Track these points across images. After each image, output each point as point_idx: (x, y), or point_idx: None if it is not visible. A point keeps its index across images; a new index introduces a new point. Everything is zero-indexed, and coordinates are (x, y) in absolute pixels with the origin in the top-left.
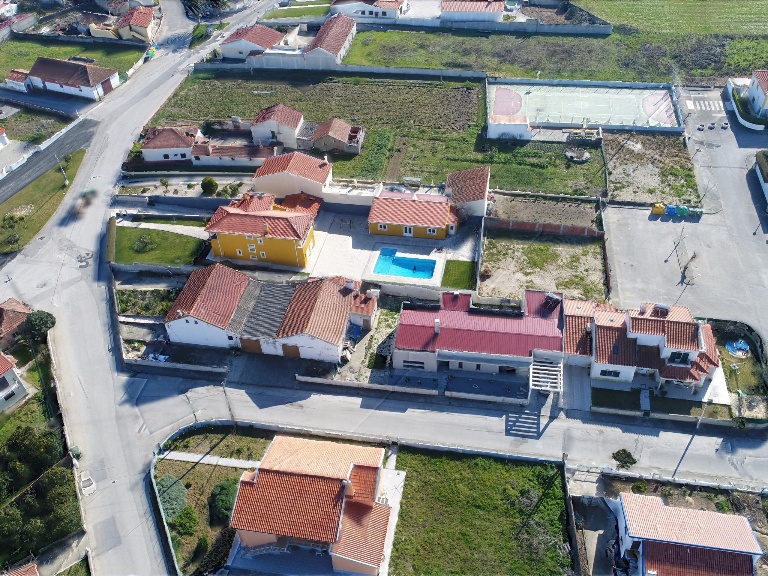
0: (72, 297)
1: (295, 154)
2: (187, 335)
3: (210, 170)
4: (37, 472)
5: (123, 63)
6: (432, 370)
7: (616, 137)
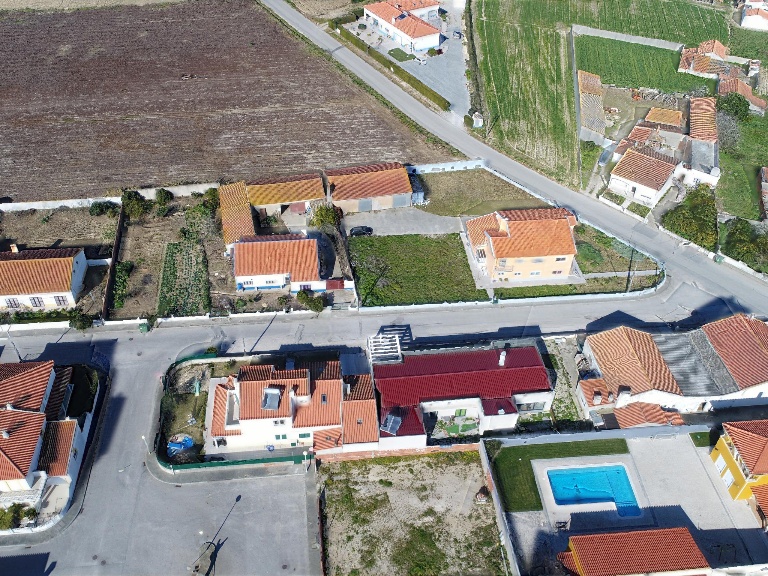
0: None
1: None
2: None
3: None
4: None
5: None
6: None
7: None
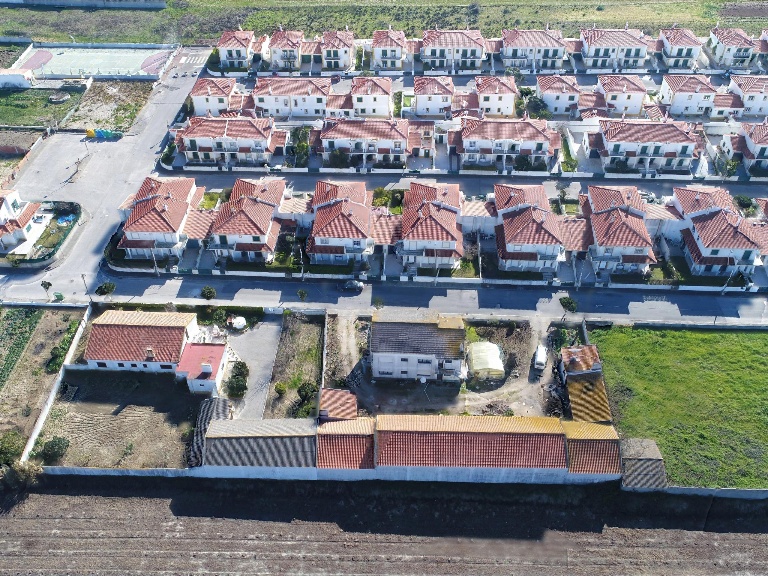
0: None
1: None
2: None
3: None
4: None
5: None
6: None
7: (103, 84)
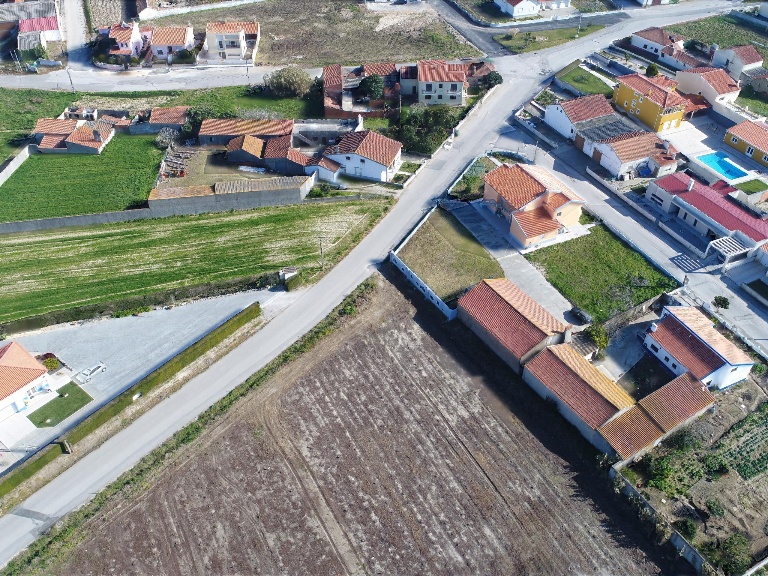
0: (521, 83)
1: (720, 69)
2: (553, 119)
3: (665, 66)
4: None
5: None
6: (666, 210)
7: None
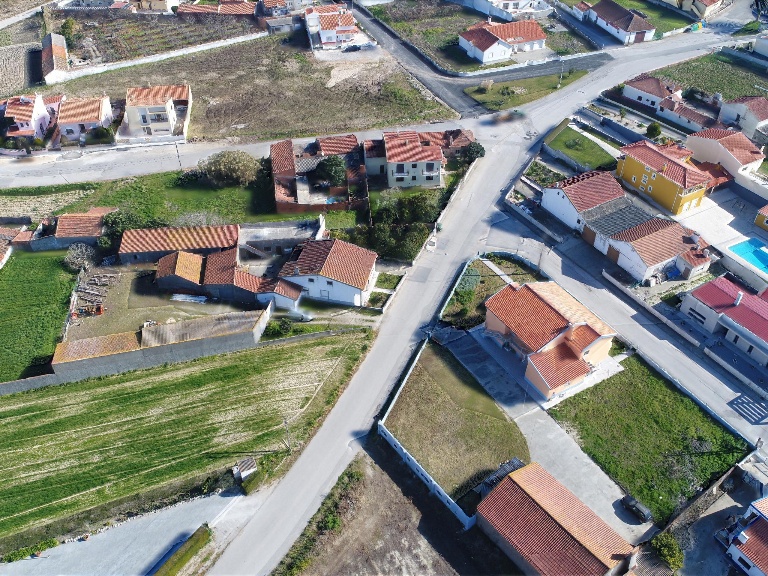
0: (505, 151)
1: (738, 133)
2: (553, 205)
3: (665, 122)
4: (413, 222)
5: (667, 27)
6: (709, 329)
7: None
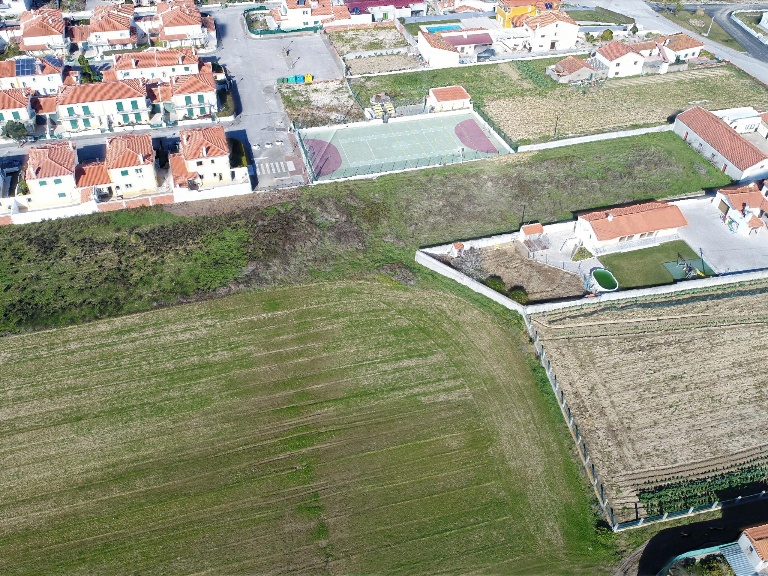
0: (594, 4)
1: None
2: None
3: None
4: None
5: None
6: None
7: (355, 120)
